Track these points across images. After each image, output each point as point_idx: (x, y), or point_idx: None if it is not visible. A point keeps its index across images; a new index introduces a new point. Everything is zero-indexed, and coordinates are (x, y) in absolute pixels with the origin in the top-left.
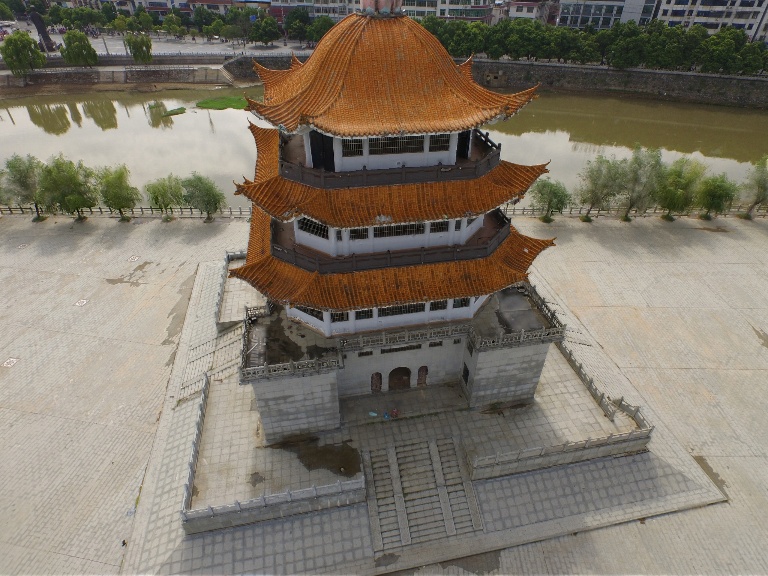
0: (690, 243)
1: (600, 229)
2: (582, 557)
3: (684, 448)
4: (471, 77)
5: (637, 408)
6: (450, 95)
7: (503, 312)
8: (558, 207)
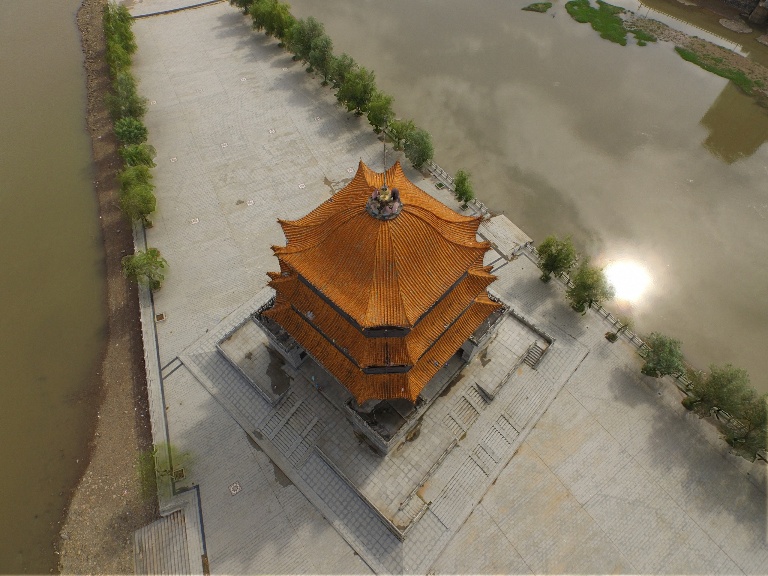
0: (747, 520)
1: (683, 423)
2: (314, 526)
3: (430, 568)
4: (473, 262)
5: (413, 520)
6: (368, 288)
7: (388, 403)
8: (661, 372)
